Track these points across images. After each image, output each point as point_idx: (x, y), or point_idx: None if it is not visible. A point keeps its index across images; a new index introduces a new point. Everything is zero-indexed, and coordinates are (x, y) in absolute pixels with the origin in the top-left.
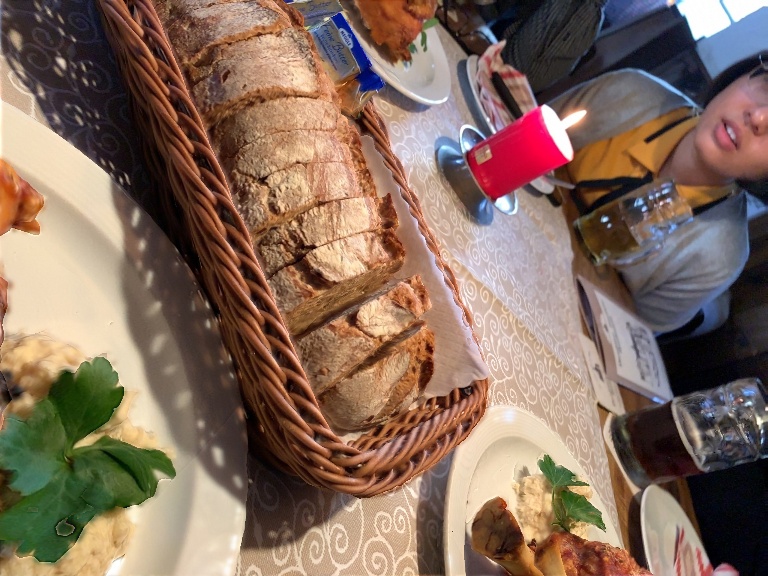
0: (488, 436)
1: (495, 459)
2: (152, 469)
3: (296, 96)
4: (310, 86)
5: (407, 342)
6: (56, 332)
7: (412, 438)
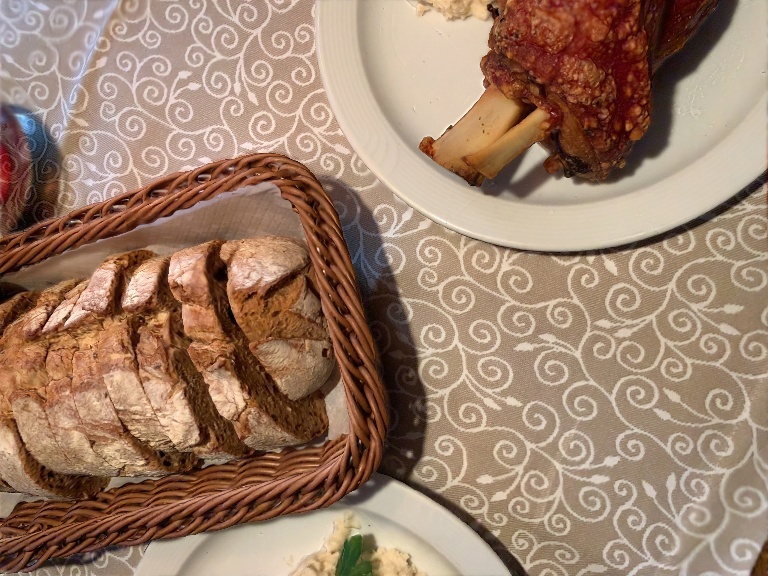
0: (353, 77)
1: (383, 57)
2: (354, 567)
3: (23, 444)
4: (5, 432)
5: (247, 332)
6: (271, 569)
7: (340, 364)
